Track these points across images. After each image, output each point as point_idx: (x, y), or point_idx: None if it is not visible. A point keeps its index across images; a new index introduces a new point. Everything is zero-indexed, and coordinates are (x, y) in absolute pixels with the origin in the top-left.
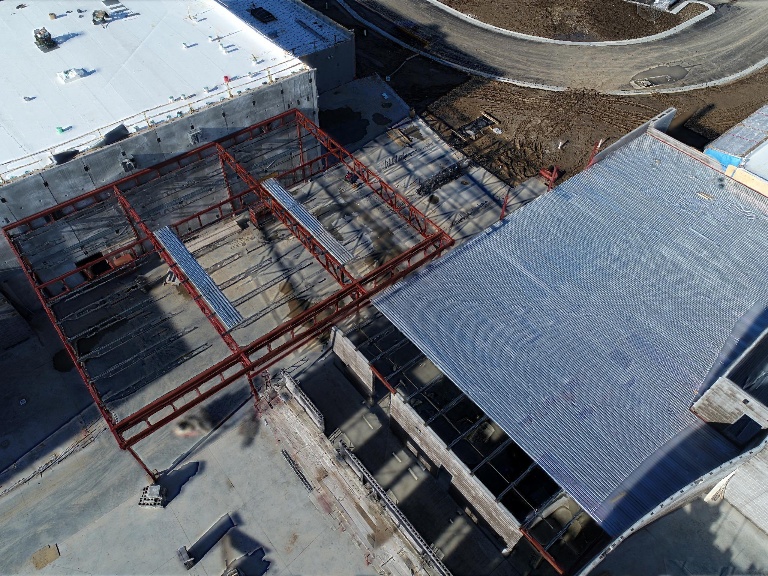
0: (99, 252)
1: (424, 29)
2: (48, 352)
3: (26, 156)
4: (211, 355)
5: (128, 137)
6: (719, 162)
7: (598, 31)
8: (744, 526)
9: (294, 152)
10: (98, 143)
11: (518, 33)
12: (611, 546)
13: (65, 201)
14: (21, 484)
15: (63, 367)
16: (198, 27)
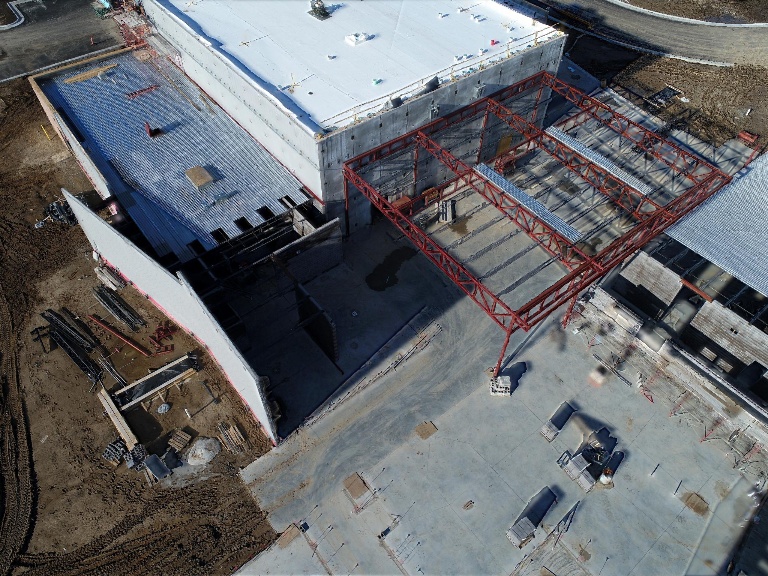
0: None
1: (582, 12)
2: (359, 275)
3: (375, 99)
4: (501, 280)
5: (439, 88)
6: None
7: (745, 14)
8: None
9: (529, 112)
10: (420, 91)
11: (671, 16)
12: None
13: (386, 142)
14: (381, 376)
15: (377, 287)
16: (441, 0)
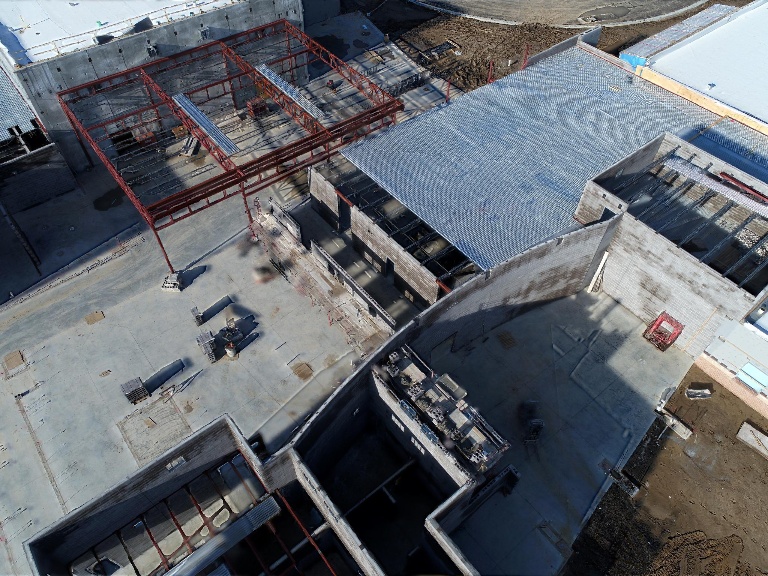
0: (128, 127)
1: None
2: (89, 198)
3: (76, 35)
4: None
5: (152, 28)
6: (631, 64)
7: None
8: (615, 307)
9: None
10: (130, 30)
11: None
12: (490, 269)
13: (104, 77)
14: (74, 277)
15: (101, 208)
16: None
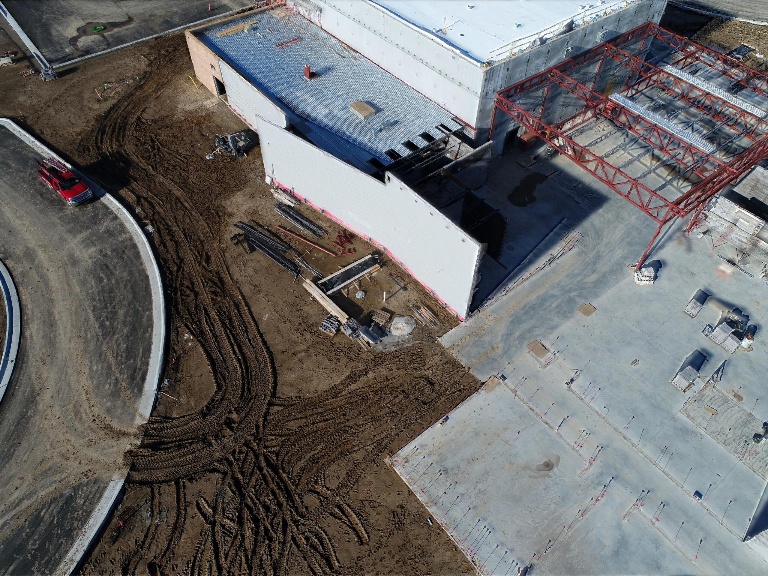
0: (519, 126)
1: None
2: (501, 195)
3: (528, 36)
4: None
5: (574, 30)
6: None
7: None
8: None
9: None
10: (561, 32)
11: None
12: None
13: (528, 77)
14: (540, 270)
15: (519, 204)
16: None
